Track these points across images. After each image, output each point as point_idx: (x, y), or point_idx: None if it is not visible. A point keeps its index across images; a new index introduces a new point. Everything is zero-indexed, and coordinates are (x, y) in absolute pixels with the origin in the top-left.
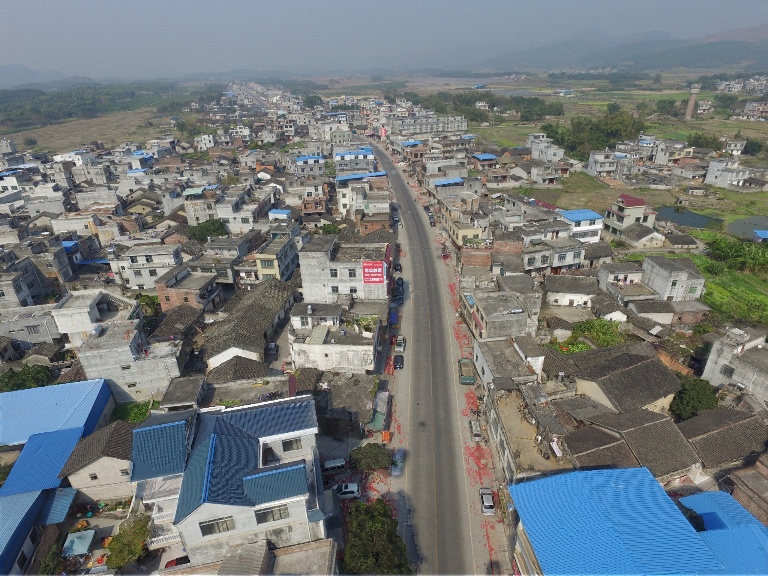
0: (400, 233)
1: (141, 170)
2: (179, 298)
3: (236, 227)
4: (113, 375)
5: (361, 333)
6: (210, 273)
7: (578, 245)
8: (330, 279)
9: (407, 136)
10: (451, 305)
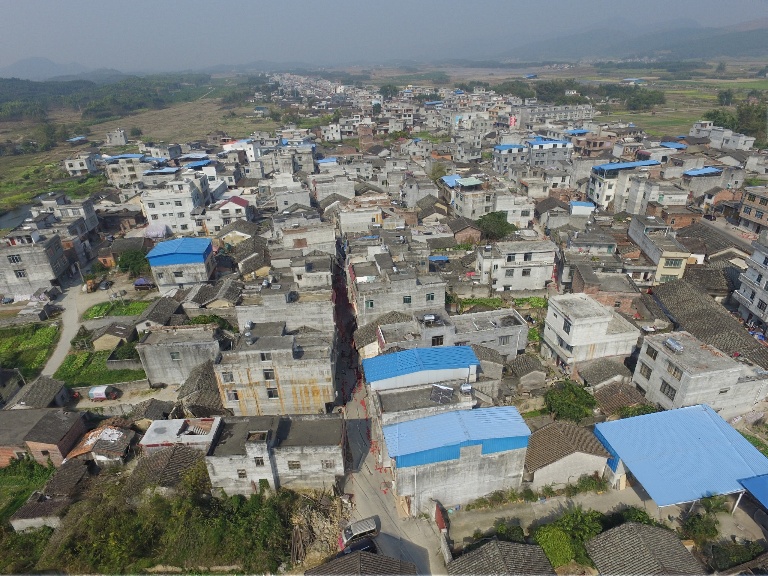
0: None
1: (333, 160)
2: (609, 302)
3: (513, 221)
4: (707, 400)
5: None
6: (617, 273)
7: None
8: None
9: (562, 124)
10: None
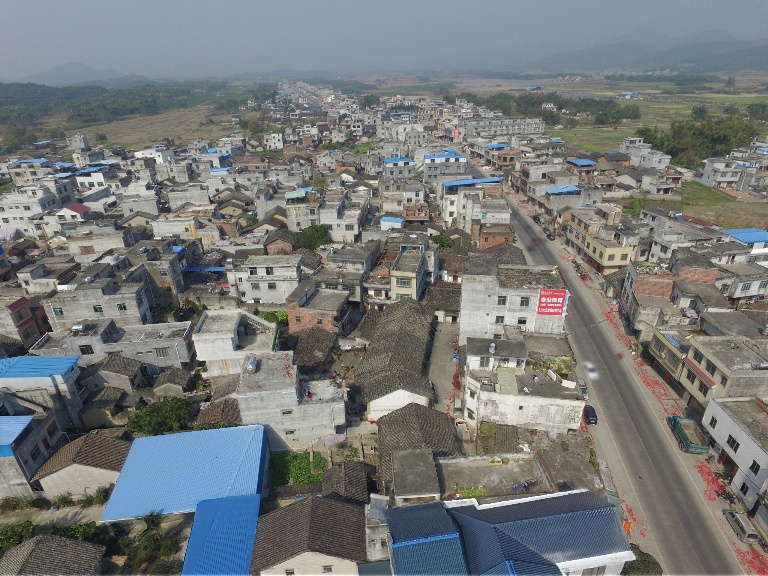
0: (517, 246)
1: (224, 169)
2: (311, 319)
3: (339, 234)
4: (271, 420)
5: (560, 381)
6: (341, 291)
7: (767, 273)
8: (496, 307)
9: (489, 138)
10: (619, 340)
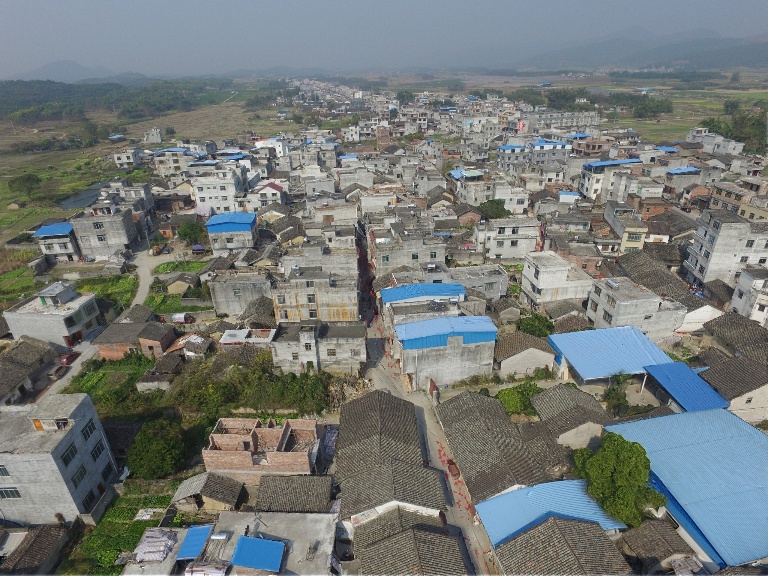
0: None
1: (354, 156)
2: None
3: (509, 208)
4: (635, 323)
5: None
6: (587, 244)
7: None
8: (744, 249)
9: (565, 129)
10: None
